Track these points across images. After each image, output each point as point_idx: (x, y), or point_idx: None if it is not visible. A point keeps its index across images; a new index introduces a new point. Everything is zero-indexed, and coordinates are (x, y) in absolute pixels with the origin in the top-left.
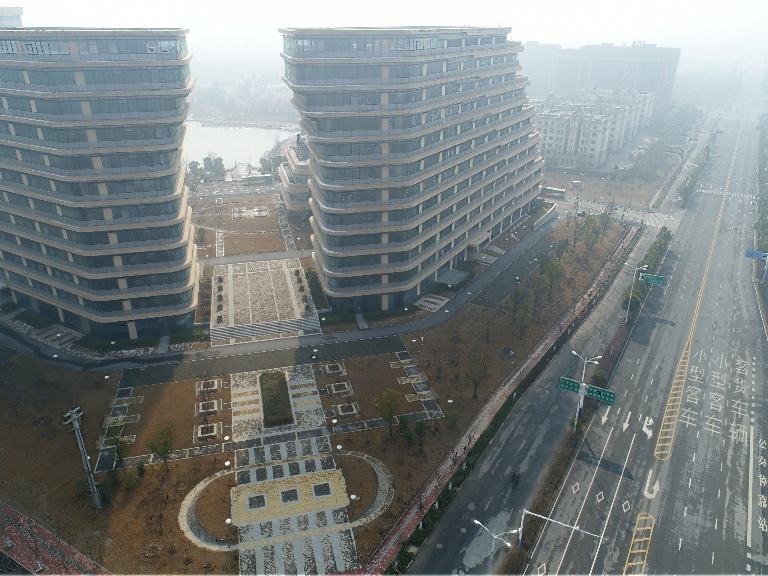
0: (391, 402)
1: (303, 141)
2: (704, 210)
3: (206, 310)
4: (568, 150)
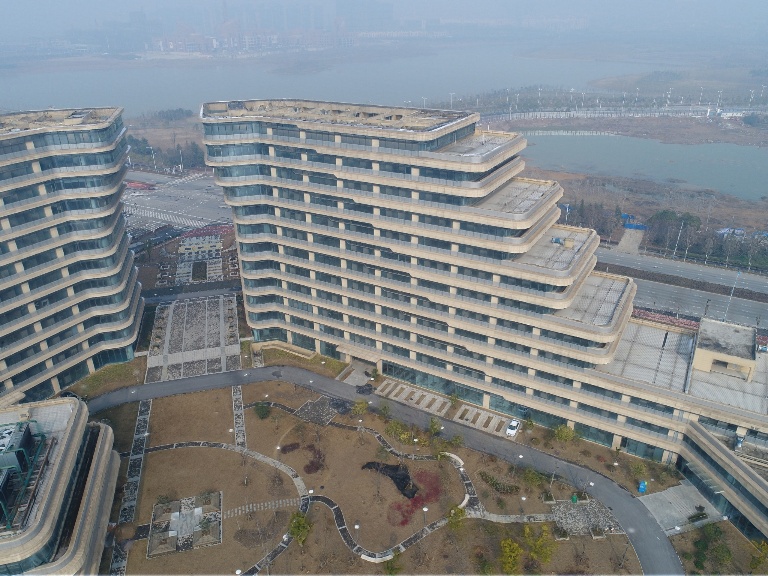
0: (147, 245)
1: (18, 448)
2: None
3: (239, 304)
4: None
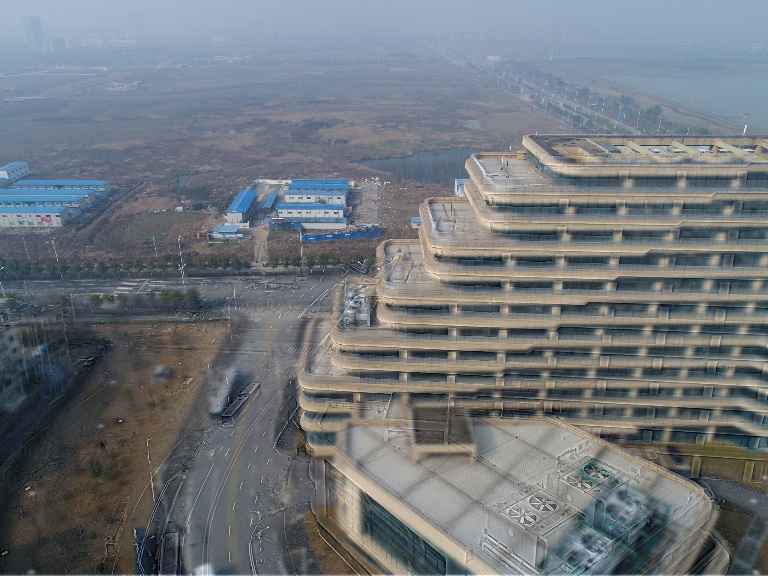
0: None
1: (602, 498)
2: (259, 334)
3: None
4: (36, 374)
